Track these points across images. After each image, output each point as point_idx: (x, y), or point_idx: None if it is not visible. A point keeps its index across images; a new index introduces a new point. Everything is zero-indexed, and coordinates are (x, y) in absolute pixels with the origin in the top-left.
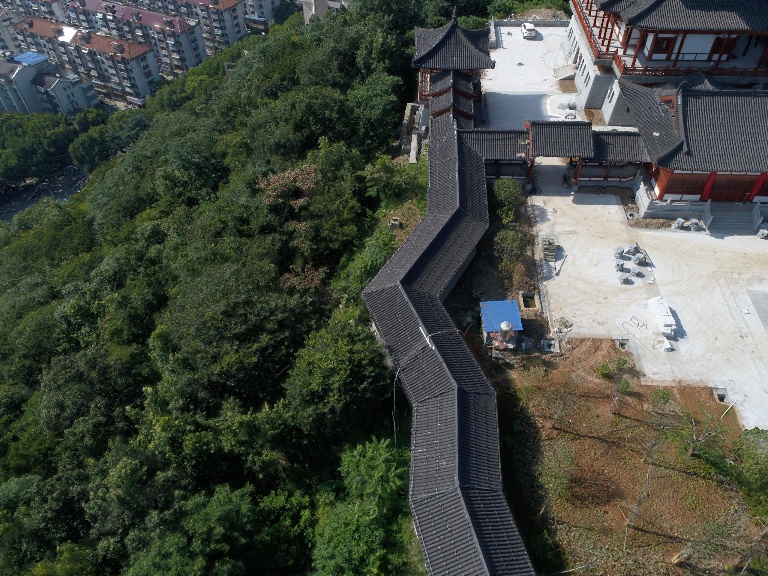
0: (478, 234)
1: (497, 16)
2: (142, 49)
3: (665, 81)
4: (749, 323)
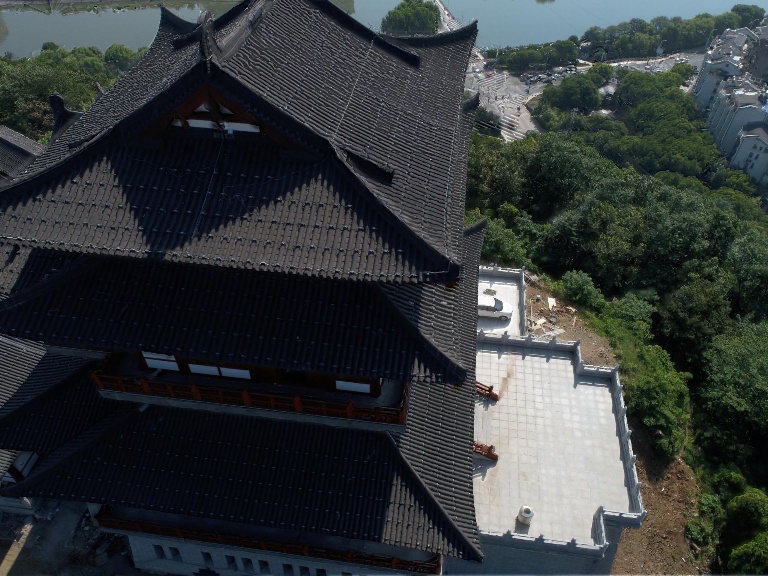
0: None
1: (555, 285)
2: None
3: None
4: None
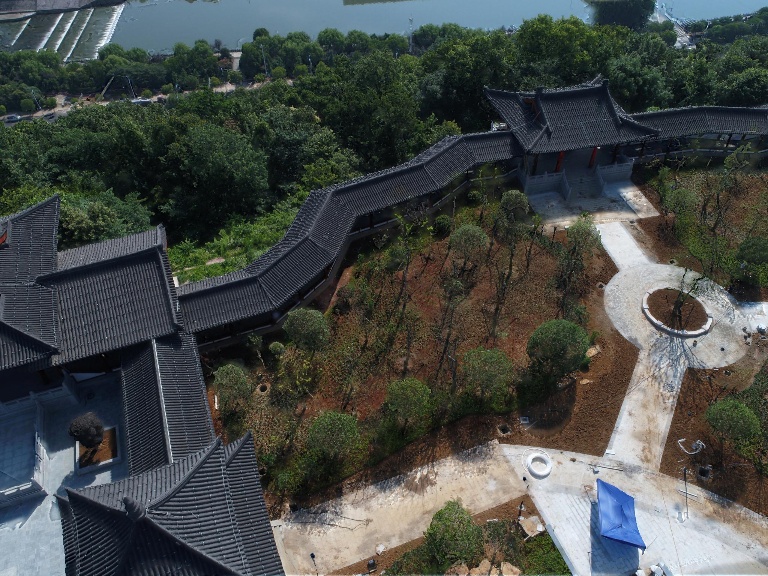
0: None
1: None
2: None
3: None
4: None
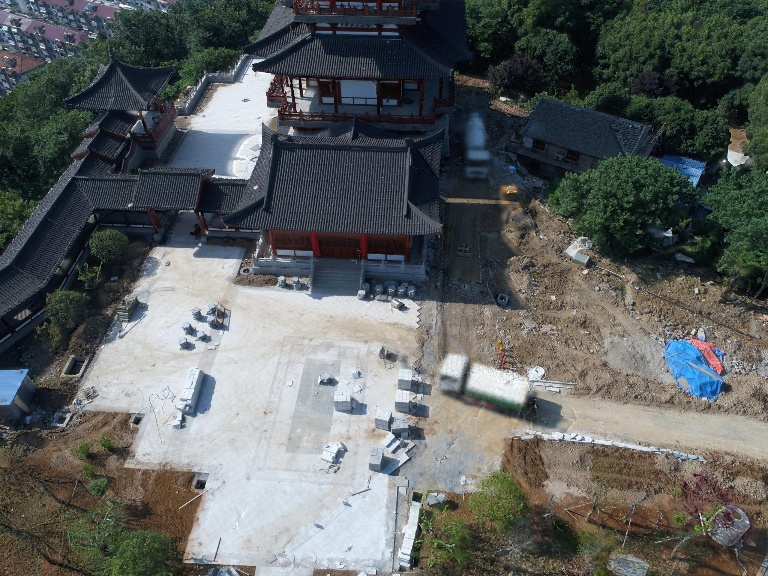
0: (26, 294)
1: None
2: (35, 63)
3: (325, 127)
4: (283, 397)
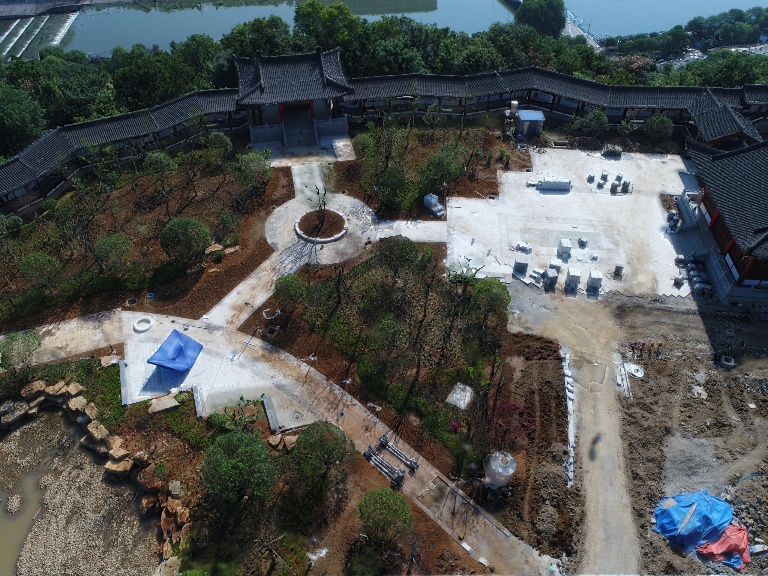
0: None
1: None
2: None
3: None
4: (562, 224)
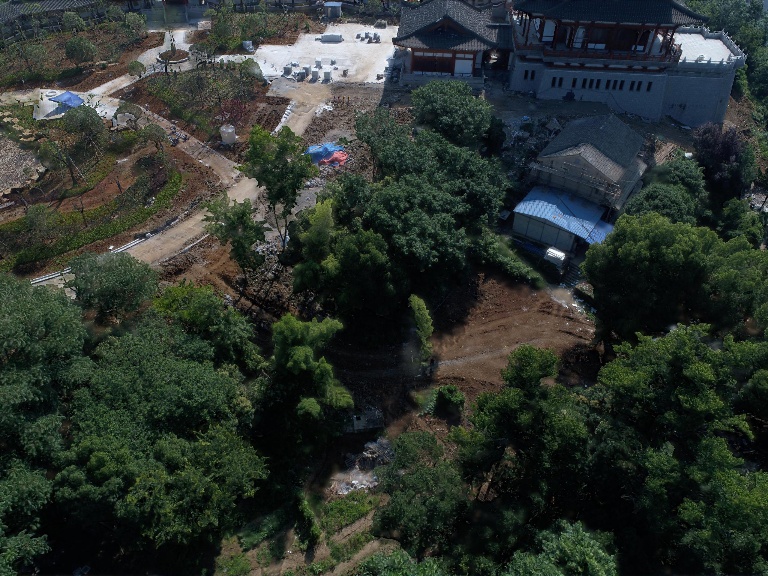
0: None
1: None
2: None
3: None
4: None
